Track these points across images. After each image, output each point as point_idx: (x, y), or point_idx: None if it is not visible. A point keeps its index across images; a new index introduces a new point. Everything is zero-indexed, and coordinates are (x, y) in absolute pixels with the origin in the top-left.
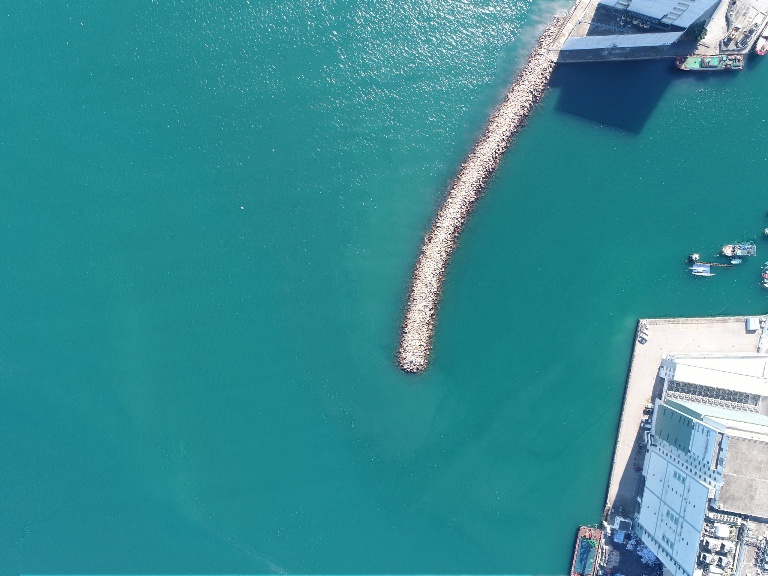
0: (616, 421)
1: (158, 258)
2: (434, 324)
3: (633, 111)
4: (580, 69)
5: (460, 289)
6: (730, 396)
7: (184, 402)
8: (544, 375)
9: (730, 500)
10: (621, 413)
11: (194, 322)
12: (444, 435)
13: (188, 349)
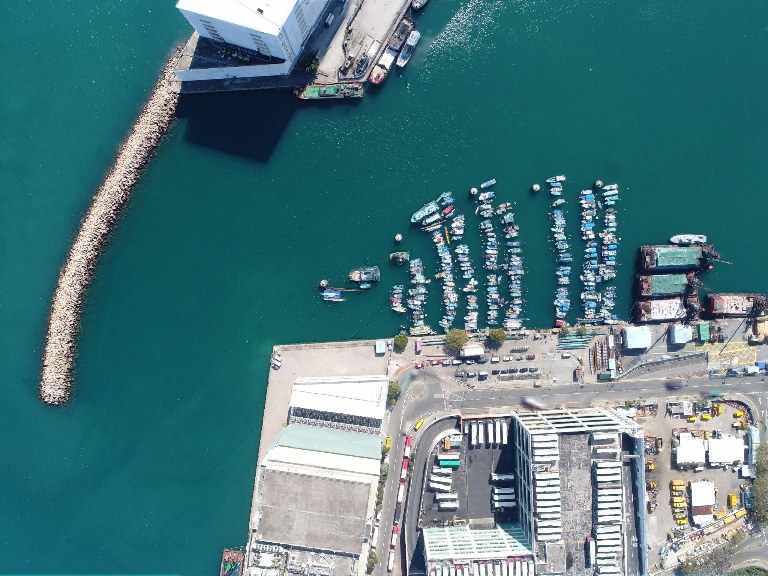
0: (257, 445)
1: None
2: (74, 356)
3: (260, 140)
4: (204, 100)
5: (101, 320)
6: (352, 419)
7: None
8: (184, 403)
9: (269, 531)
10: (260, 438)
11: None
12: (89, 465)
13: None
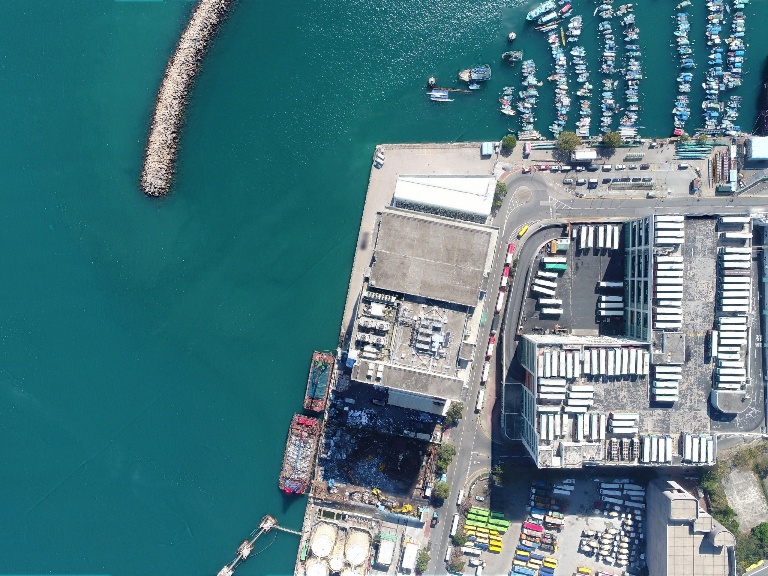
0: (353, 248)
1: None
2: (177, 148)
3: None
4: None
5: (205, 115)
6: (455, 217)
7: None
8: (283, 200)
9: (383, 277)
10: (357, 239)
11: None
12: (185, 259)
13: None
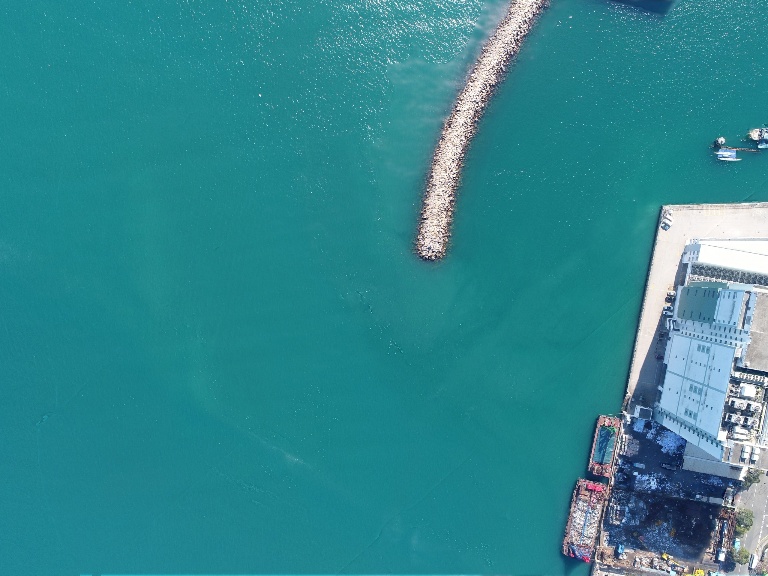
0: (637, 310)
1: (176, 137)
2: (453, 211)
3: None
4: None
5: (480, 176)
6: (755, 280)
7: (201, 284)
8: (564, 263)
9: (757, 358)
10: (642, 301)
11: (212, 200)
12: (462, 323)
13: (206, 228)
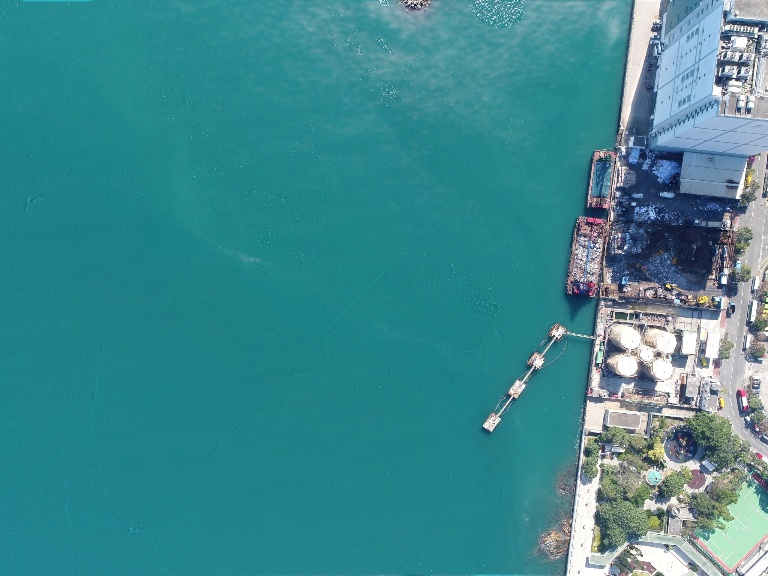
0: (625, 44)
1: None
2: None
3: None
4: None
5: None
6: None
7: (187, 38)
8: (550, 2)
9: (746, 7)
10: (629, 34)
11: None
12: (452, 71)
13: None
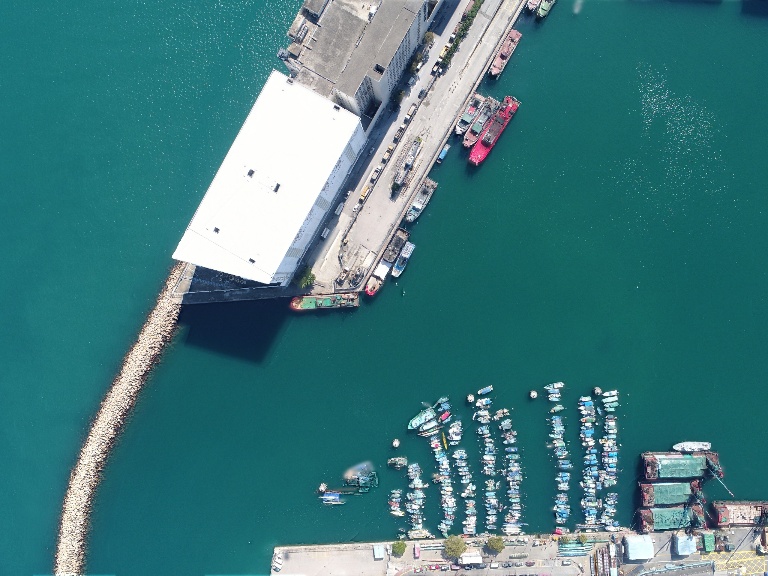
0: None
1: None
2: (85, 554)
3: (260, 347)
4: (205, 309)
5: (110, 518)
6: None
7: None
8: None
9: None
10: None
11: None
12: None
13: None
